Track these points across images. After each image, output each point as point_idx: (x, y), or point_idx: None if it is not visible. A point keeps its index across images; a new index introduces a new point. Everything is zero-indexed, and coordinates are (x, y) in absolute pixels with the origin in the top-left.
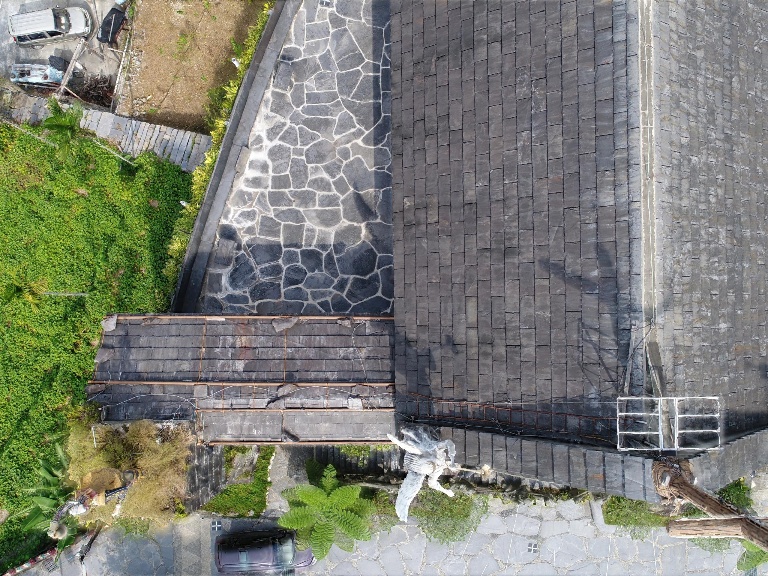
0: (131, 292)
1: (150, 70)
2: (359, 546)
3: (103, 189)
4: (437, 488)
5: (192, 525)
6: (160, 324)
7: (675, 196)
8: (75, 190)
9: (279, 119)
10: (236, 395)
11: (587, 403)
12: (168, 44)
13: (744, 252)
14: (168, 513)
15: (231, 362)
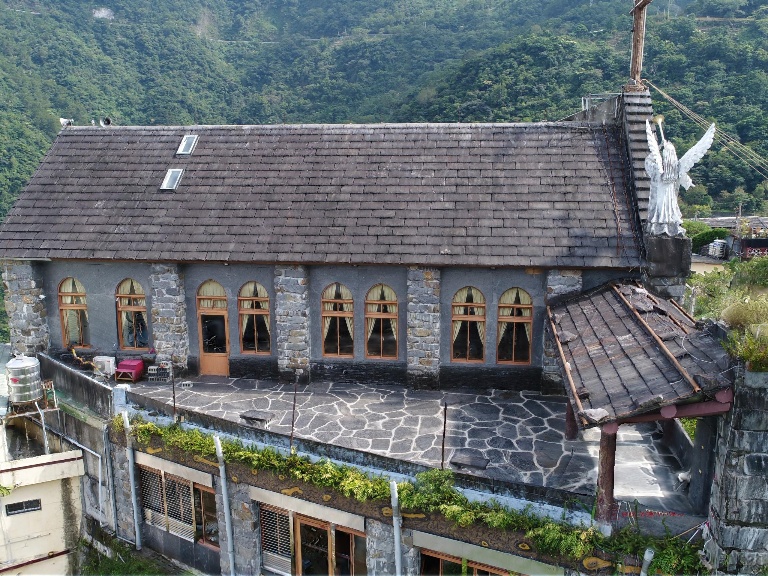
0: None
1: None
2: None
3: None
4: None
5: None
6: None
7: None
8: None
9: None
10: None
11: None
12: None
13: None
14: None
15: None
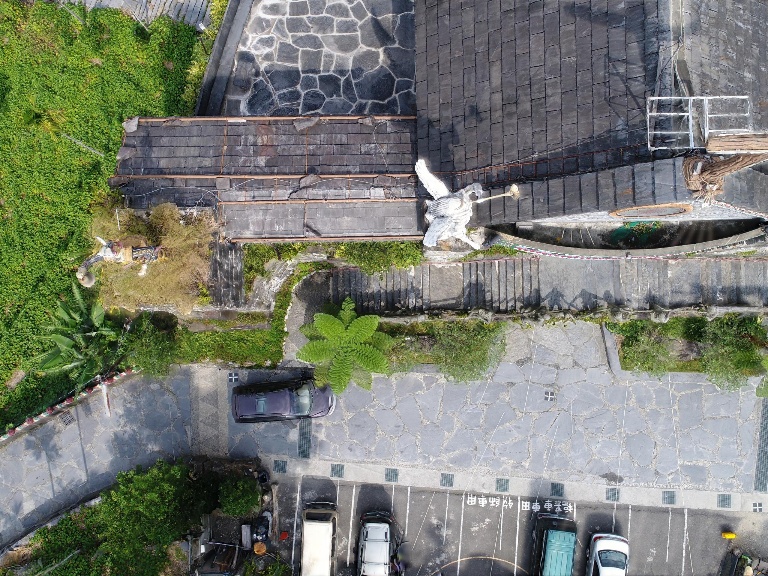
0: None
1: None
2: (376, 396)
3: (117, 57)
4: (463, 237)
5: (209, 376)
6: (181, 126)
7: None
8: (89, 60)
9: None
10: (258, 187)
11: (614, 134)
12: None
13: (767, 12)
14: (192, 296)
15: (253, 158)
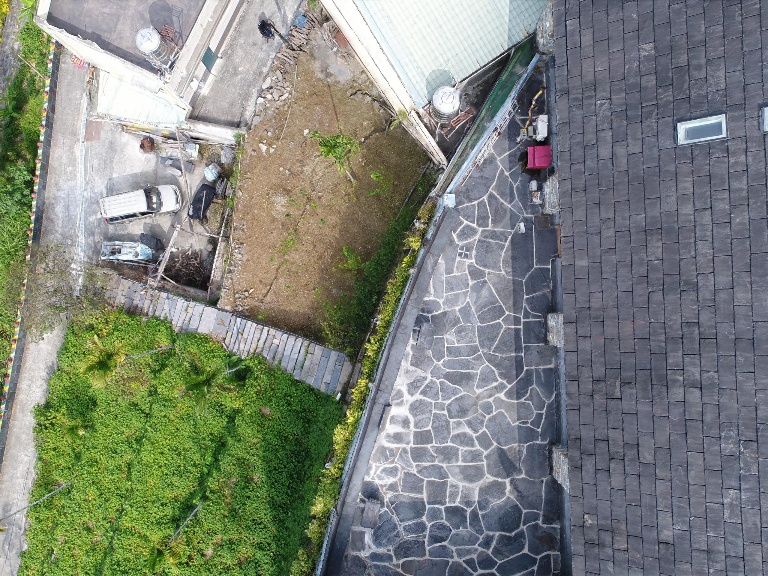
0: (245, 502)
1: (252, 263)
2: None
3: None
4: None
5: None
6: None
7: None
8: (179, 388)
9: (419, 373)
10: None
11: None
12: (269, 236)
13: None
14: None
15: None
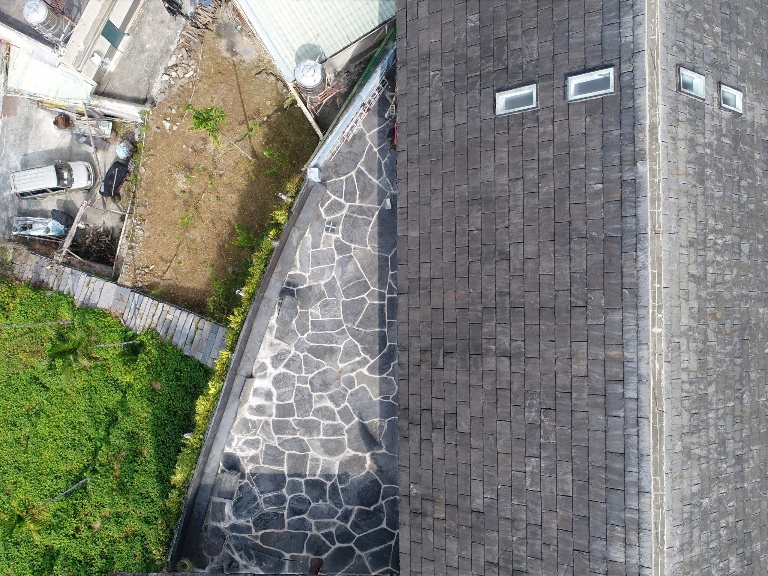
0: (133, 476)
1: (153, 239)
2: None
3: (105, 363)
4: None
5: None
6: None
7: (686, 551)
8: None
9: (284, 346)
10: None
11: None
12: (171, 213)
13: (754, 567)
14: None
15: None
